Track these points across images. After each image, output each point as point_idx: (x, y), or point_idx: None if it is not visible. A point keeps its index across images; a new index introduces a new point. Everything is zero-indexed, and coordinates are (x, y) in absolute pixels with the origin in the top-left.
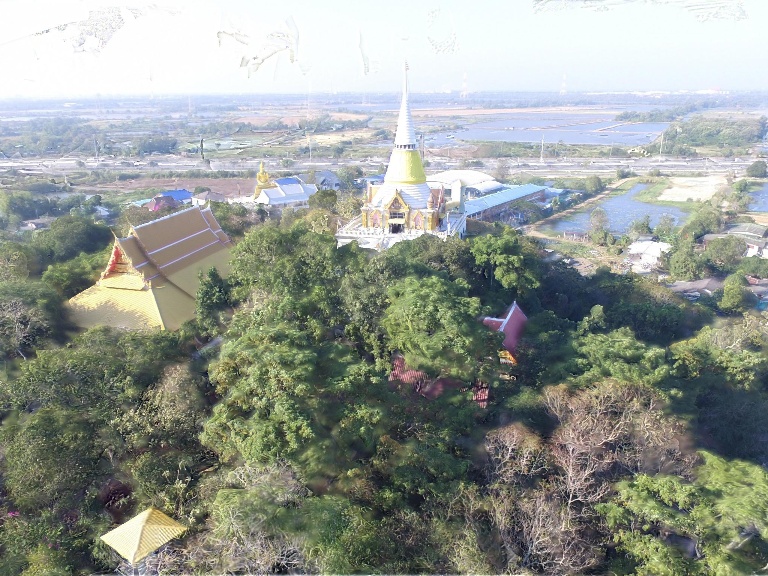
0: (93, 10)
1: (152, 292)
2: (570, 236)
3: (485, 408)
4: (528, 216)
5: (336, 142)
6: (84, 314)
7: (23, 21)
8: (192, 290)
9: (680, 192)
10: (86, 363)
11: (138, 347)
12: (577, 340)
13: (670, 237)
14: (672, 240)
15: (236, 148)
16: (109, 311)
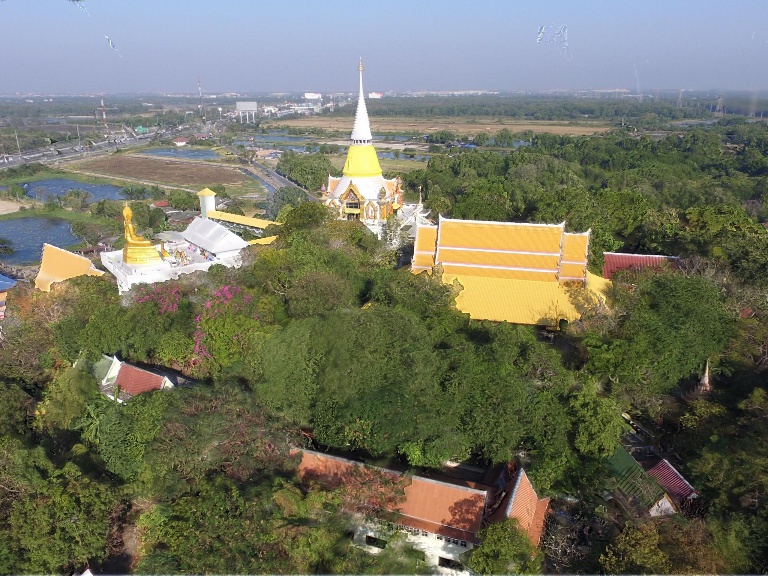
0: None
1: None
2: (87, 254)
3: None
4: None
5: None
6: None
7: None
8: None
9: None
10: None
11: None
12: None
13: (166, 225)
14: (170, 227)
15: None
16: None
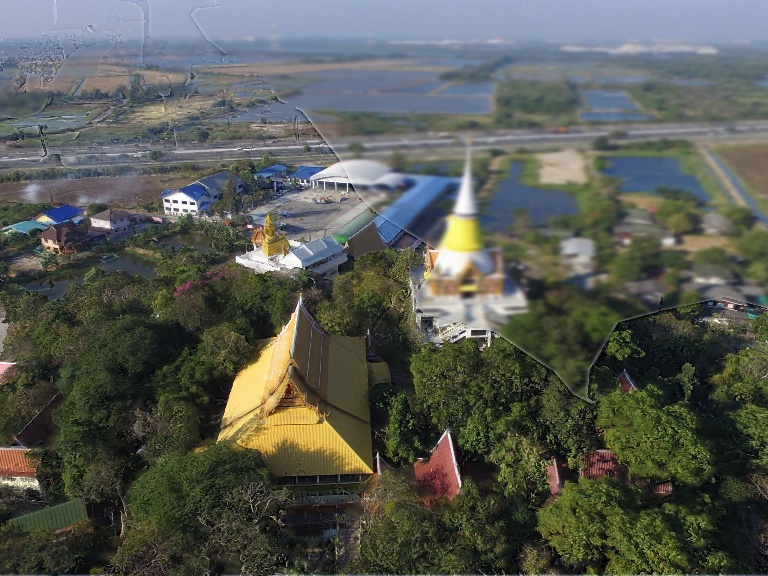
0: (30, 42)
1: (328, 424)
2: None
3: (673, 489)
4: None
5: (179, 116)
6: (266, 461)
7: (466, 281)
8: (350, 408)
9: None
10: (465, 568)
11: (483, 533)
12: (737, 421)
13: None
14: None
15: (66, 130)
16: (293, 453)
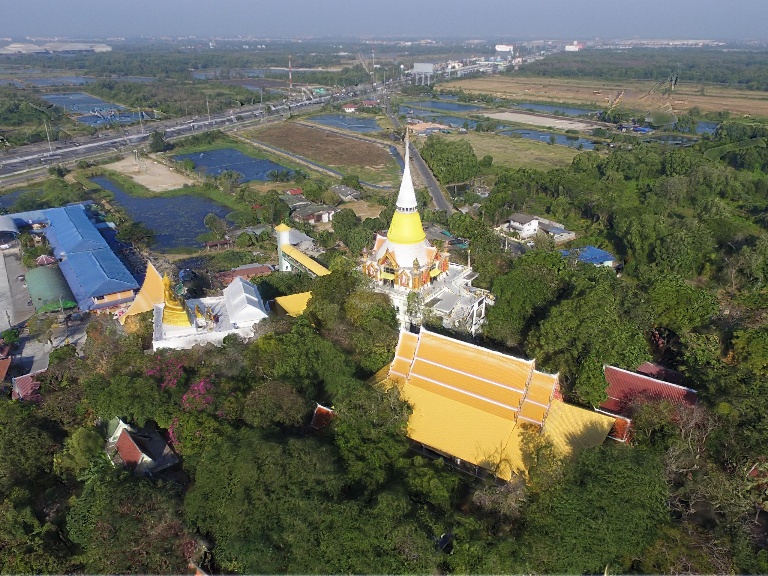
0: None
1: (567, 404)
2: (212, 247)
3: None
4: (140, 242)
5: None
6: None
7: None
8: None
9: (151, 180)
10: None
11: None
12: None
13: (286, 222)
14: (289, 224)
15: None
16: (579, 440)
